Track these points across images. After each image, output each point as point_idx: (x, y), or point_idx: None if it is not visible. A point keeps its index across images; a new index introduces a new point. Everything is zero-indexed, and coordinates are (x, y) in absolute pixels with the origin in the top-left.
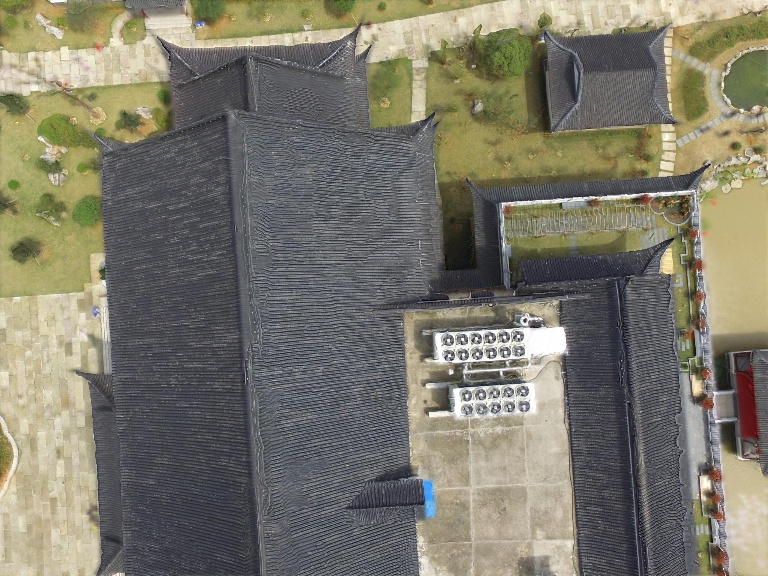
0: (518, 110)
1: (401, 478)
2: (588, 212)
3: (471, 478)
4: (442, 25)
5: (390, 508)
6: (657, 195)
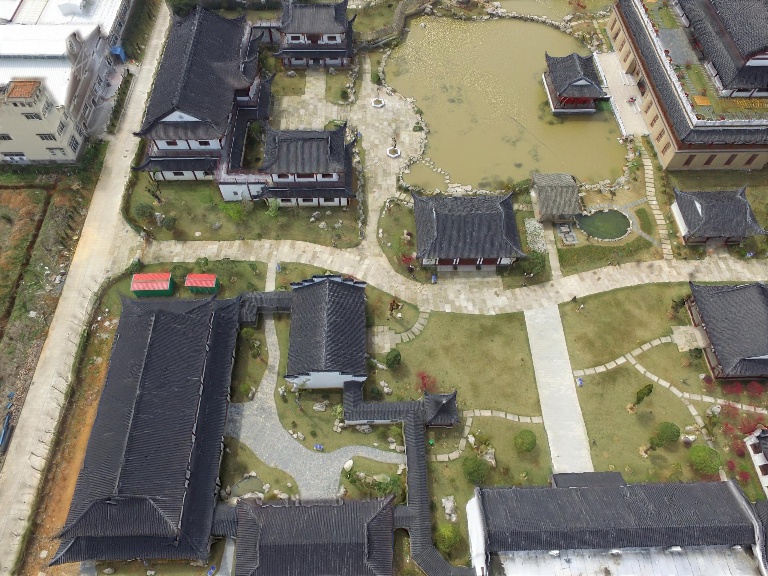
0: None
1: None
2: (762, 105)
3: None
4: None
5: None
6: (713, 124)
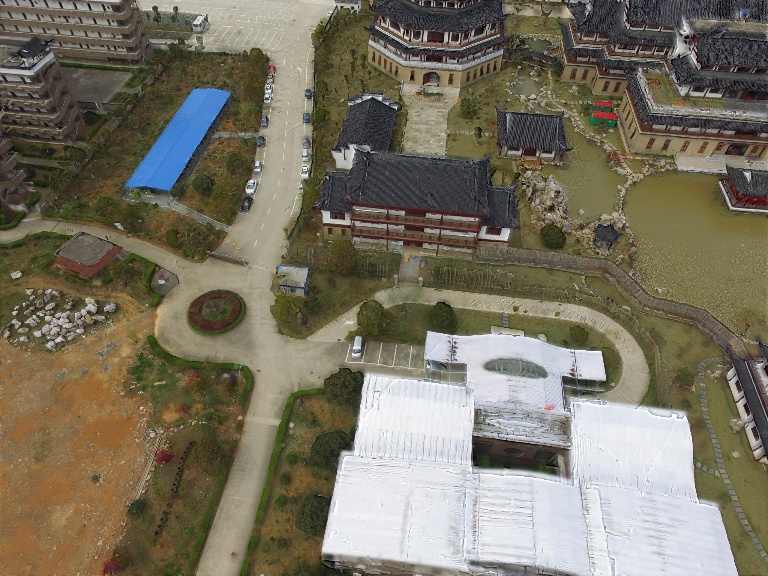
0: None
1: None
2: None
3: None
4: None
5: (736, 13)
6: None
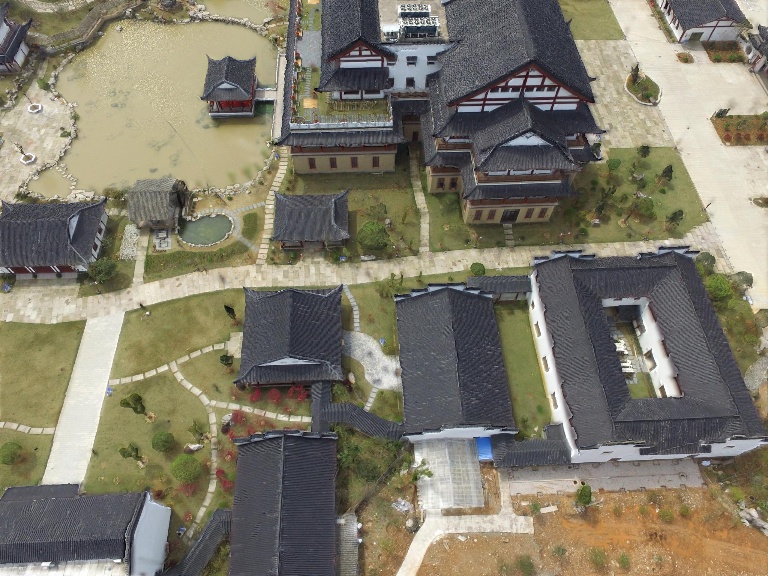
0: (363, 222)
1: (449, 1)
2: (352, 108)
3: (420, 3)
4: (410, 270)
5: None
6: (308, 127)
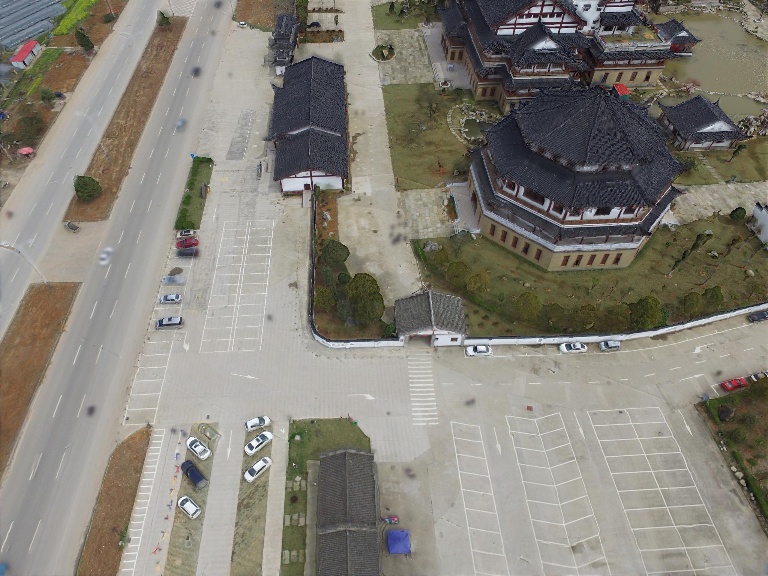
0: None
1: None
2: None
3: None
4: None
5: None
6: None
